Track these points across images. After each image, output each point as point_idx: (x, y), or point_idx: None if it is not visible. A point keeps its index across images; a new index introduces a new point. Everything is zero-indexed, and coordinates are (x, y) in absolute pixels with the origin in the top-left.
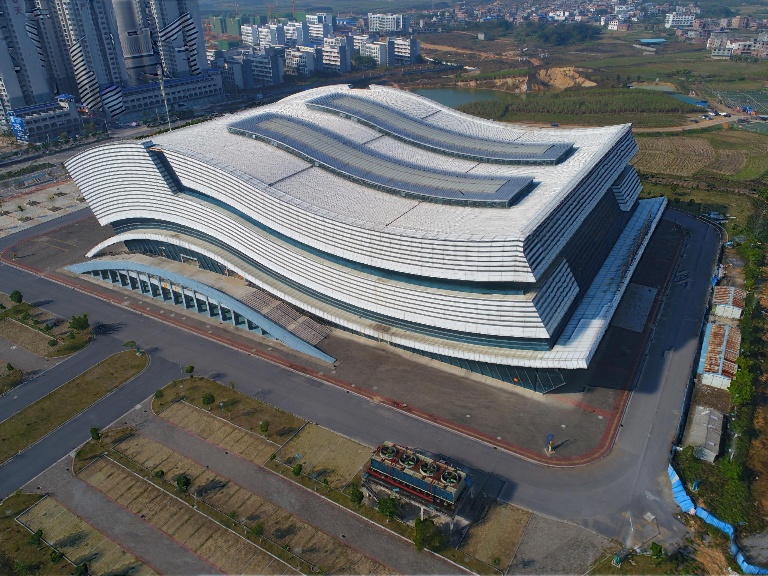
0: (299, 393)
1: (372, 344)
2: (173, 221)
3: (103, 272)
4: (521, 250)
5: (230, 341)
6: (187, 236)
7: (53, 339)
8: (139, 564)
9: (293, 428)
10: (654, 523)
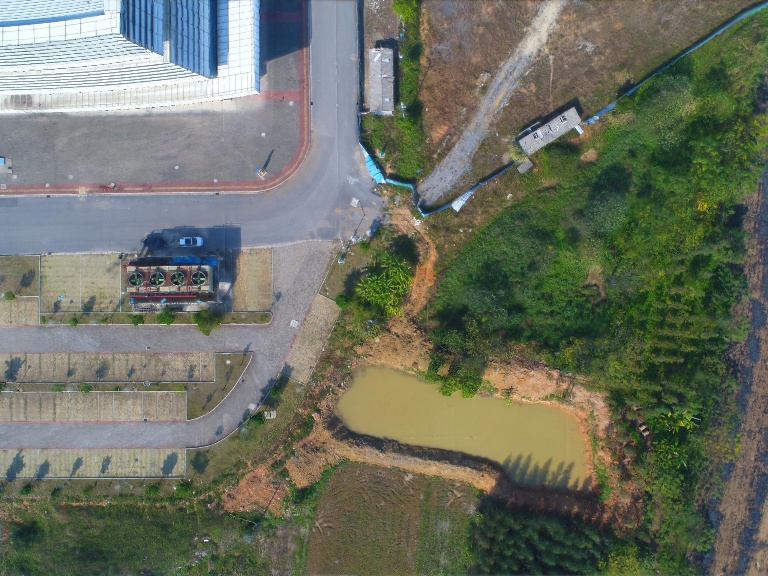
0: (3, 225)
1: None
2: None
3: None
4: (124, 40)
5: None
6: None
7: None
8: (24, 452)
9: (32, 271)
10: (359, 207)
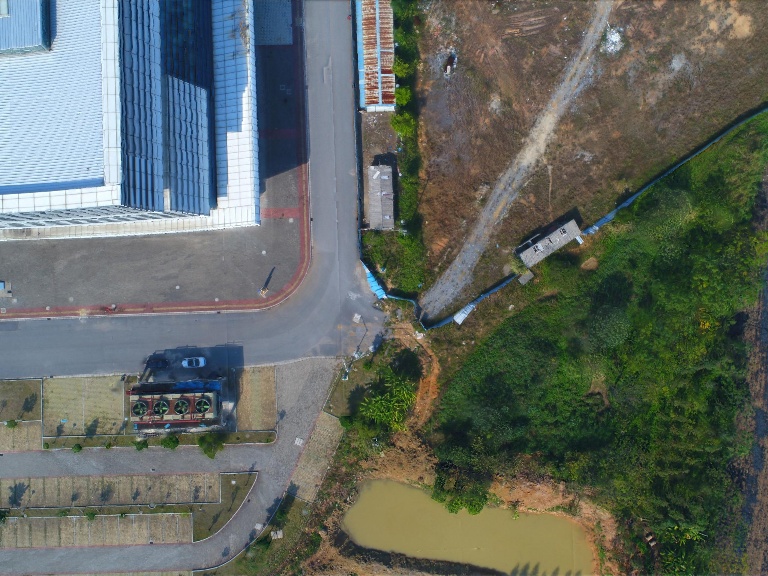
0: (4, 350)
1: None
2: None
3: None
4: (125, 207)
5: None
6: None
7: None
8: None
9: (34, 395)
10: (361, 323)
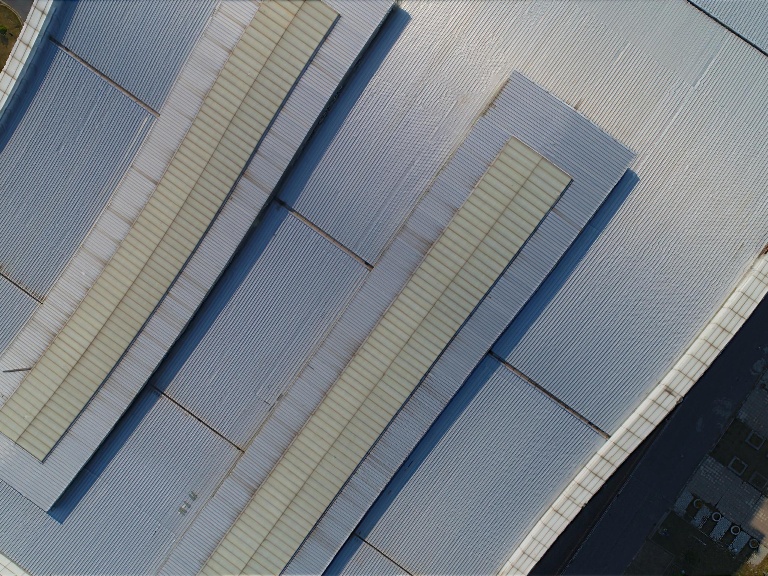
0: None
1: None
2: None
3: None
4: None
5: None
6: None
7: None
8: None
9: None
10: None
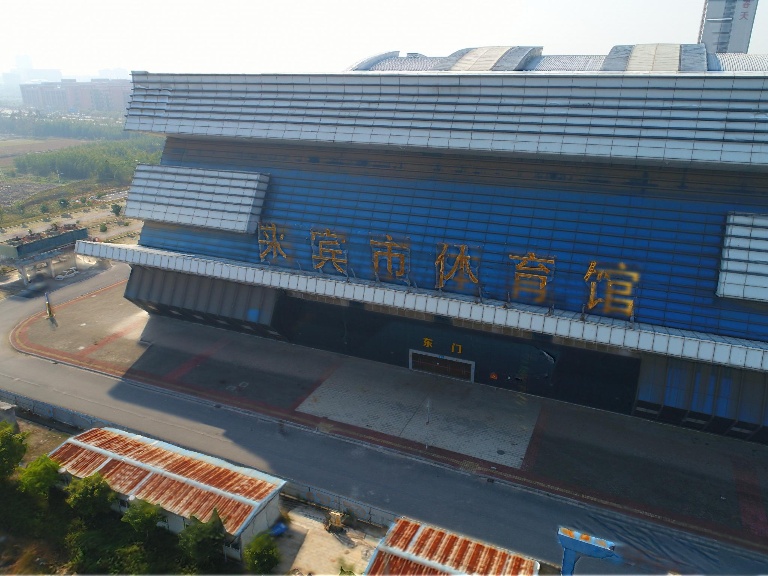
0: None
1: None
2: None
3: None
4: None
5: None
6: None
7: None
8: None
9: None
10: None
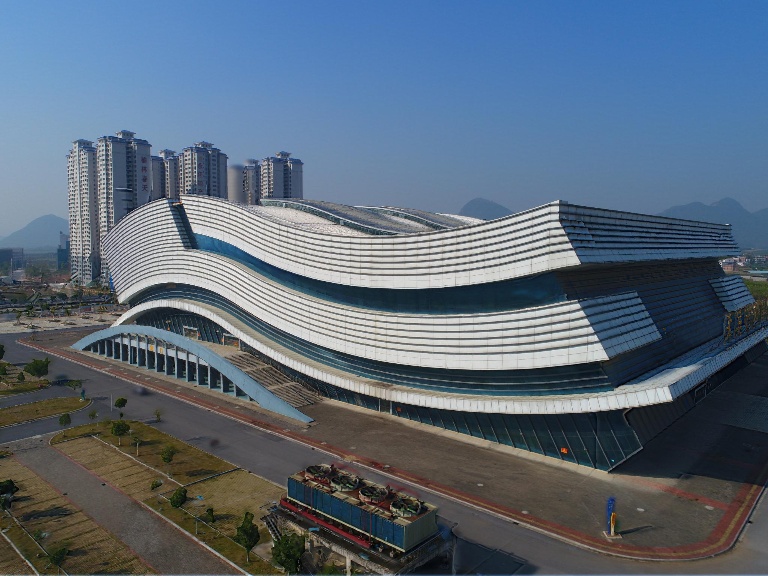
0: (246, 443)
1: (369, 412)
2: (180, 282)
3: (102, 345)
4: (556, 218)
5: (195, 399)
6: (192, 300)
7: (4, 384)
8: None
9: (213, 471)
10: None
